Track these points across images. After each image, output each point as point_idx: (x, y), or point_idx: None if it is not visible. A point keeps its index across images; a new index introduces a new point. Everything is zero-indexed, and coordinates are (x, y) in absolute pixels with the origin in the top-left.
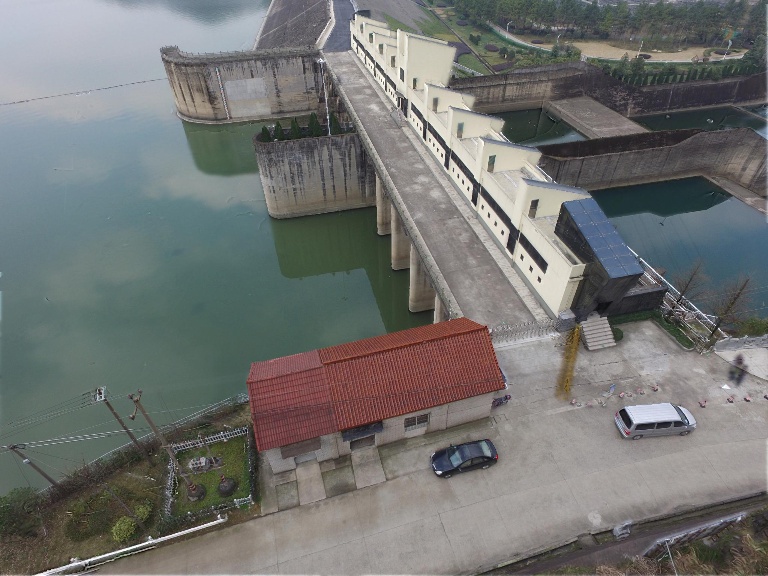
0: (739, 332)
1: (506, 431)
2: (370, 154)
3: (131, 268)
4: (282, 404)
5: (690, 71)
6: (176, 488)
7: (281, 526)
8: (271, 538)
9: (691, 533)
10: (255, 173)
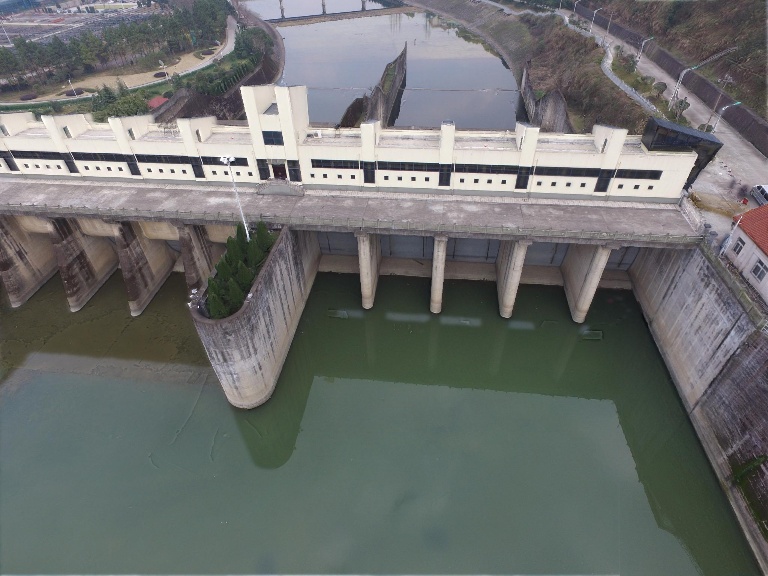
0: None
1: None
2: (362, 226)
3: None
4: None
5: (237, 70)
6: None
7: None
8: None
9: None
10: (94, 412)
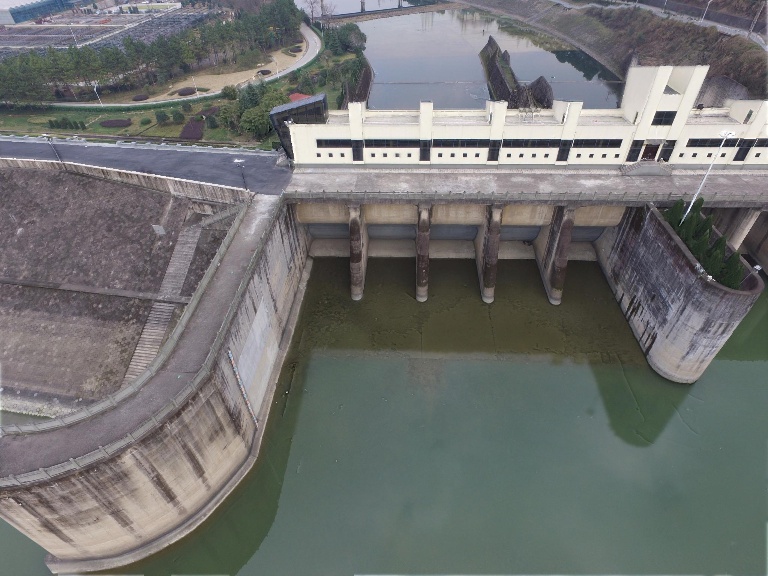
0: None
1: None
2: None
3: None
4: None
5: (357, 66)
6: None
7: None
8: None
9: None
10: (537, 396)
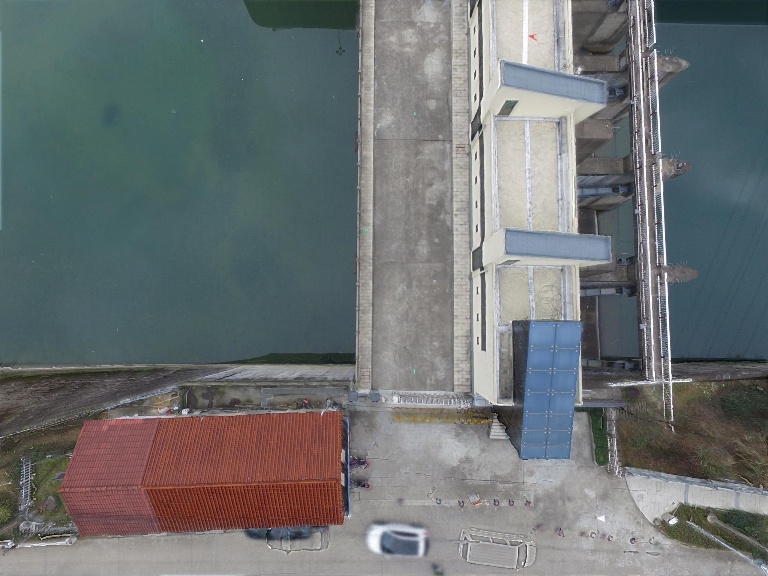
0: (674, 457)
1: (353, 512)
2: None
3: (16, 7)
4: (100, 511)
5: None
6: (33, 494)
7: (124, 551)
8: (115, 559)
9: None
10: None
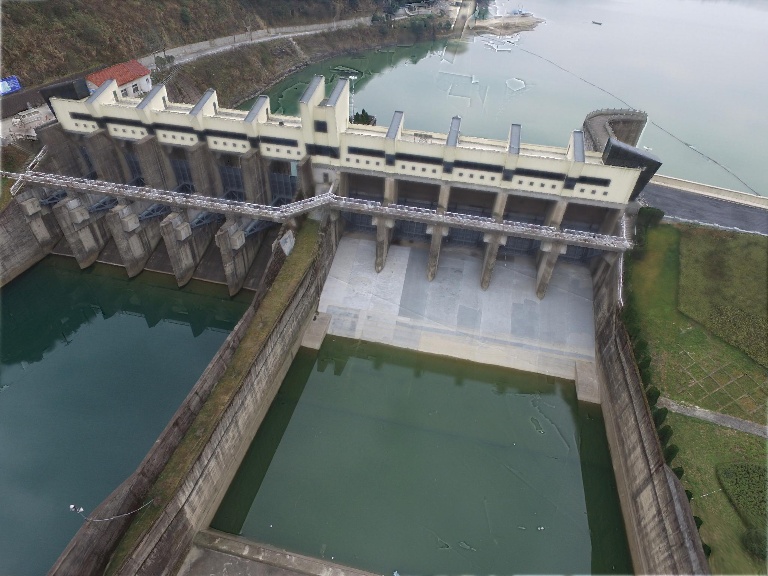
0: None
1: None
2: None
3: None
4: None
5: None
6: None
7: None
8: None
9: (7, 77)
10: None
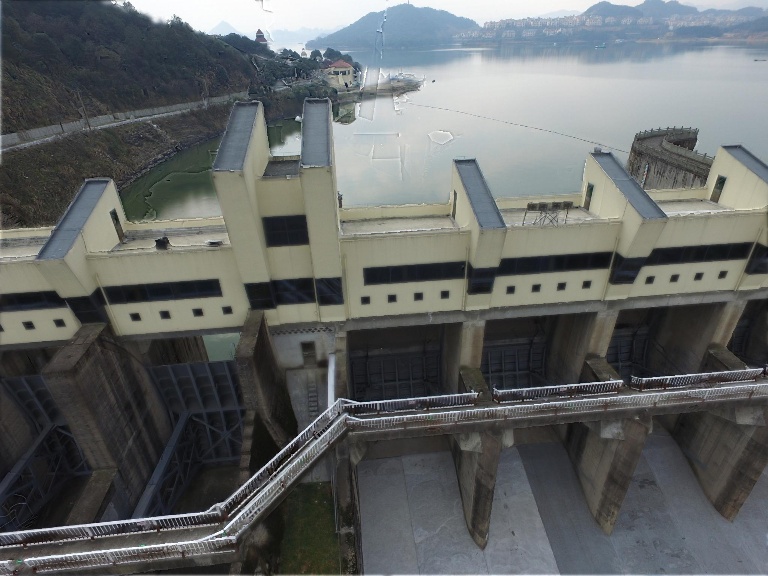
0: None
1: None
2: None
3: None
4: None
5: None
6: None
7: None
8: None
9: None
10: None
